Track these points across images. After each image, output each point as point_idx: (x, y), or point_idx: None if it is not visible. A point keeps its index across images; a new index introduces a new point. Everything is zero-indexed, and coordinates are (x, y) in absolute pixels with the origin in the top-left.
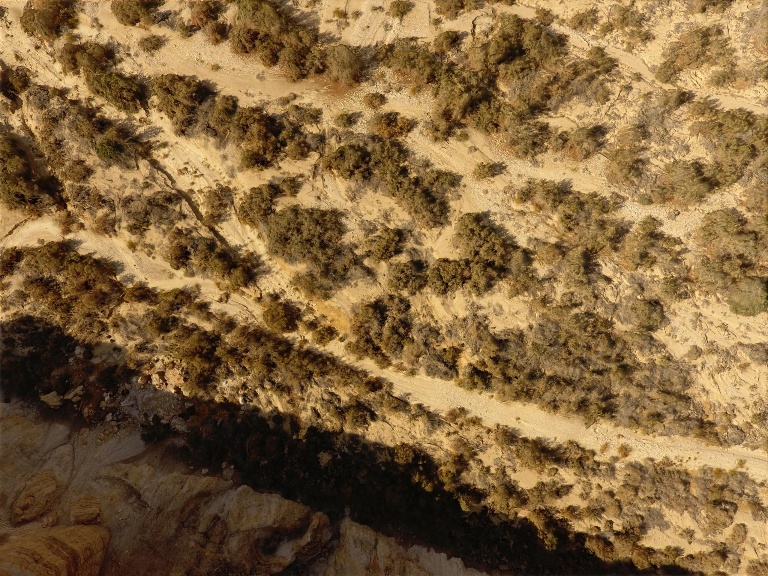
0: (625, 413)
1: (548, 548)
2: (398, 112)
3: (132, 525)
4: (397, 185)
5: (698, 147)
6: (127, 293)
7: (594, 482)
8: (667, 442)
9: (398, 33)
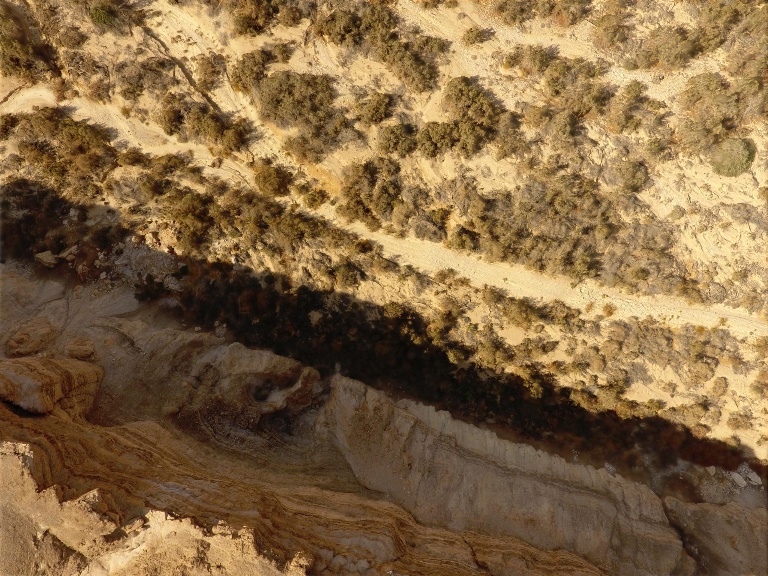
0: (610, 270)
1: (534, 396)
2: None
3: (125, 365)
4: (387, 48)
5: (682, 13)
6: (121, 156)
7: (579, 338)
8: (651, 301)
9: None
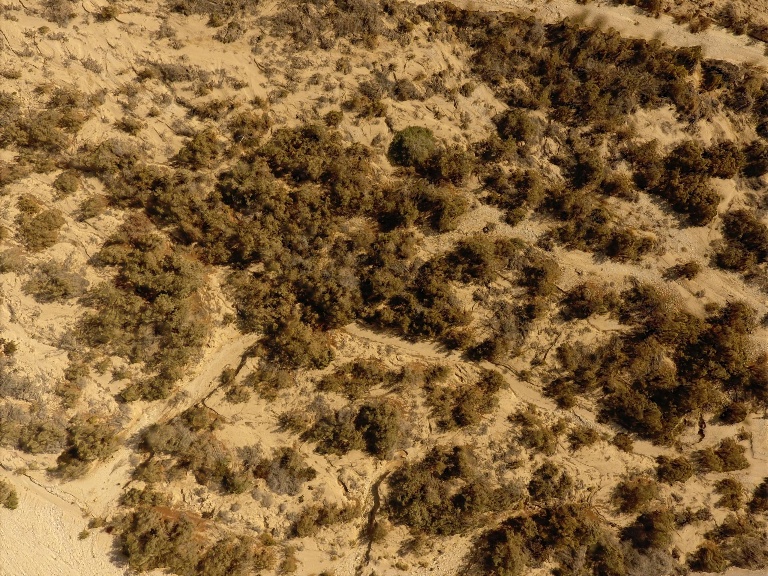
0: (540, 28)
1: None
2: None
3: None
4: None
5: (464, 299)
6: None
7: None
8: (488, 7)
9: None
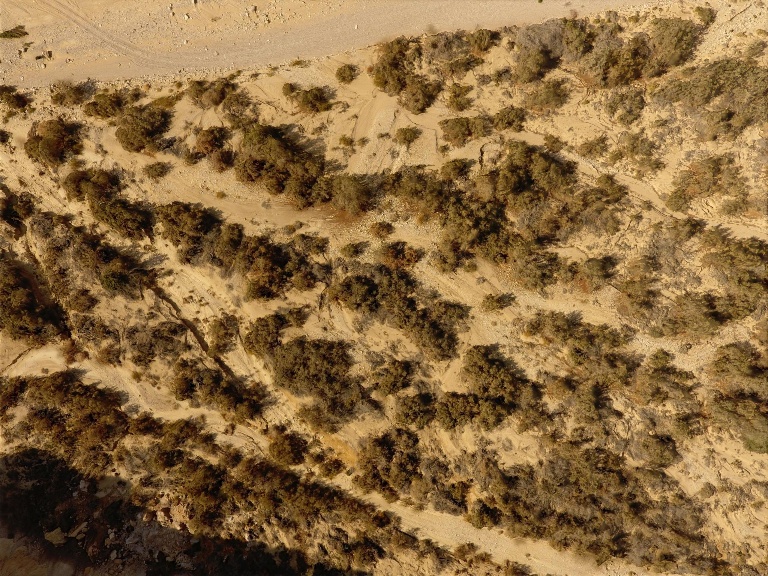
0: (637, 553)
1: None
2: (405, 241)
3: None
4: (405, 319)
5: (710, 279)
6: (132, 426)
7: None
8: None
9: (405, 161)
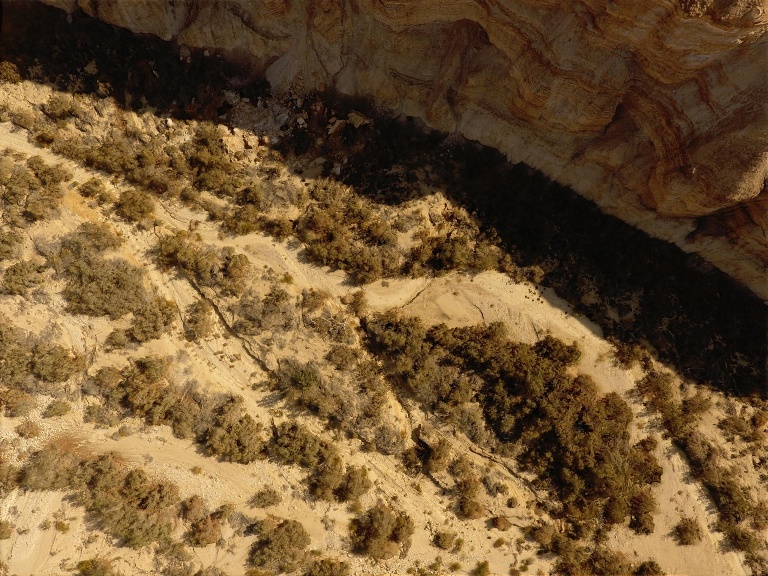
0: None
1: None
2: (6, 417)
3: None
4: (1, 338)
5: None
6: (287, 229)
7: None
8: None
9: (2, 504)
